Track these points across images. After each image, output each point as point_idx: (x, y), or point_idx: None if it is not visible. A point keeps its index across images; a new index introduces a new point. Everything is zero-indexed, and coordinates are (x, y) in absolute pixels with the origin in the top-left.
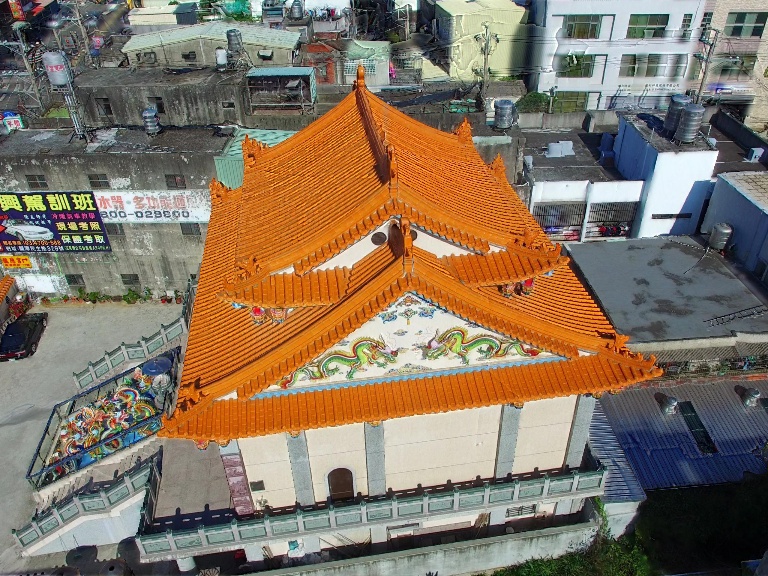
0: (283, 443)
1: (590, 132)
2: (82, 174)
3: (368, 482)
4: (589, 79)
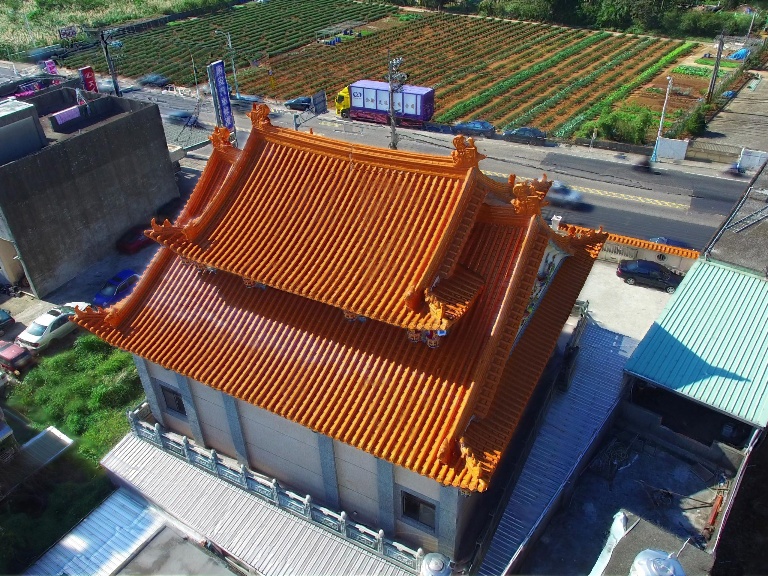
0: None
1: None
2: None
3: None
4: None
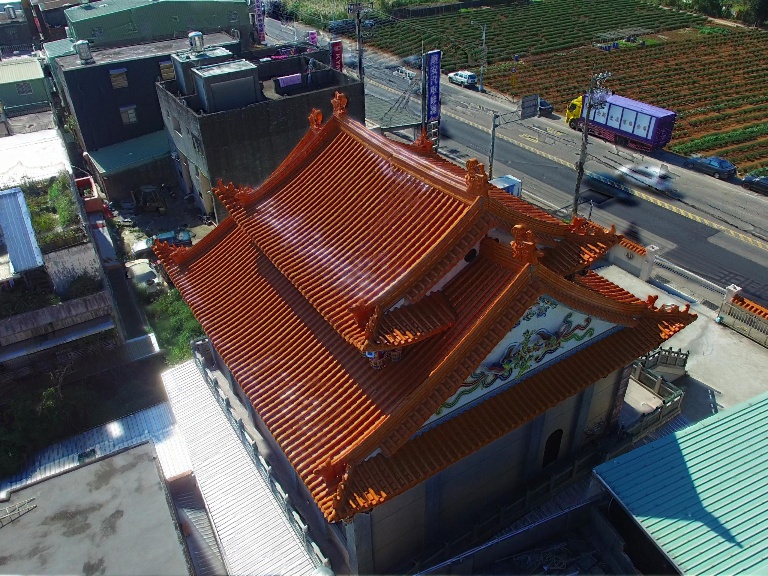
0: None
1: None
2: None
3: None
4: None
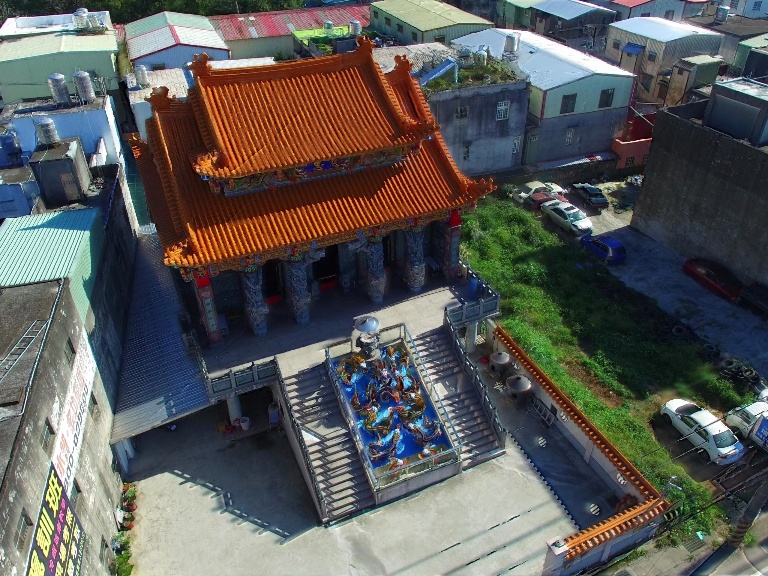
0: None
1: None
2: (39, 447)
3: None
4: None
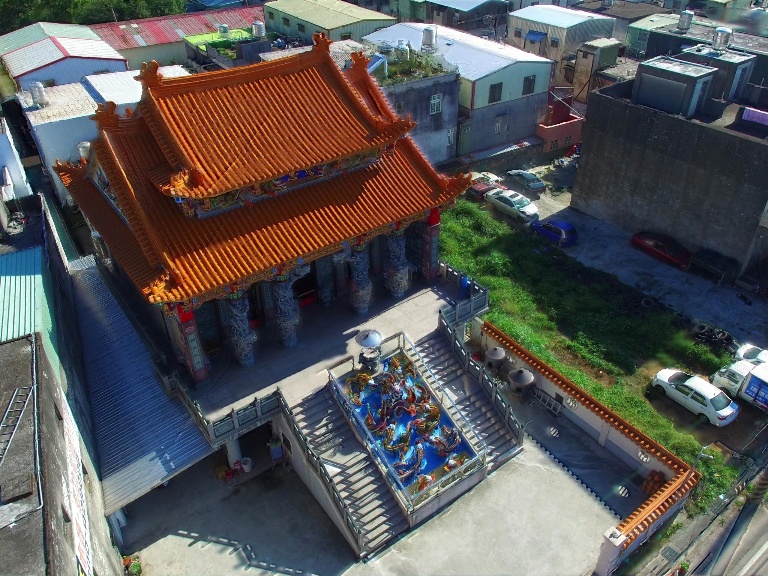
0: None
1: None
2: (64, 542)
3: None
4: None
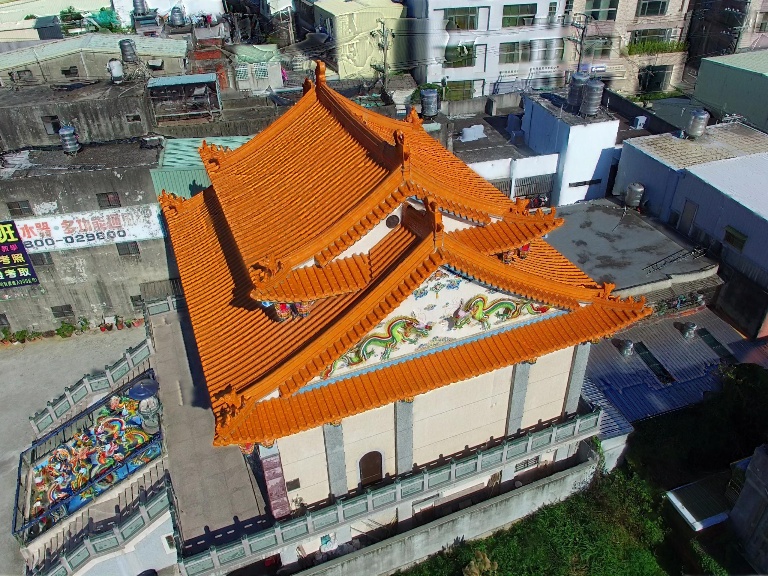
0: (319, 436)
1: (493, 115)
2: None
3: (397, 461)
4: (473, 68)
